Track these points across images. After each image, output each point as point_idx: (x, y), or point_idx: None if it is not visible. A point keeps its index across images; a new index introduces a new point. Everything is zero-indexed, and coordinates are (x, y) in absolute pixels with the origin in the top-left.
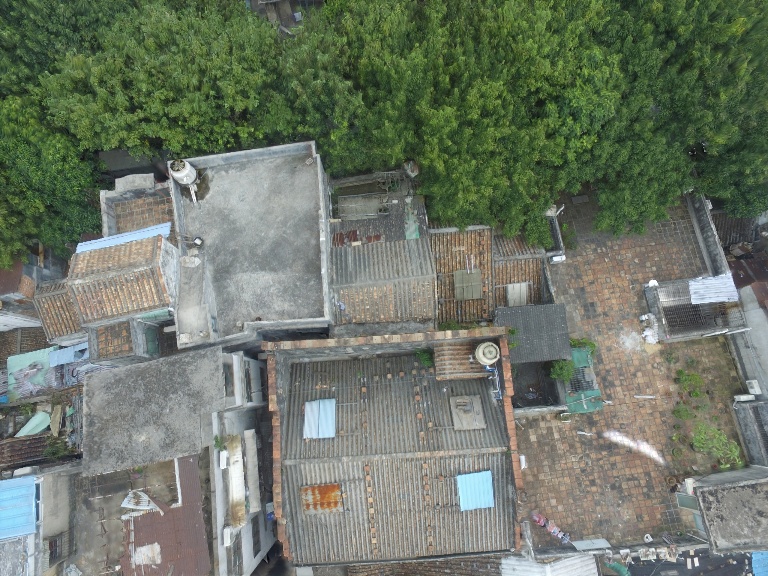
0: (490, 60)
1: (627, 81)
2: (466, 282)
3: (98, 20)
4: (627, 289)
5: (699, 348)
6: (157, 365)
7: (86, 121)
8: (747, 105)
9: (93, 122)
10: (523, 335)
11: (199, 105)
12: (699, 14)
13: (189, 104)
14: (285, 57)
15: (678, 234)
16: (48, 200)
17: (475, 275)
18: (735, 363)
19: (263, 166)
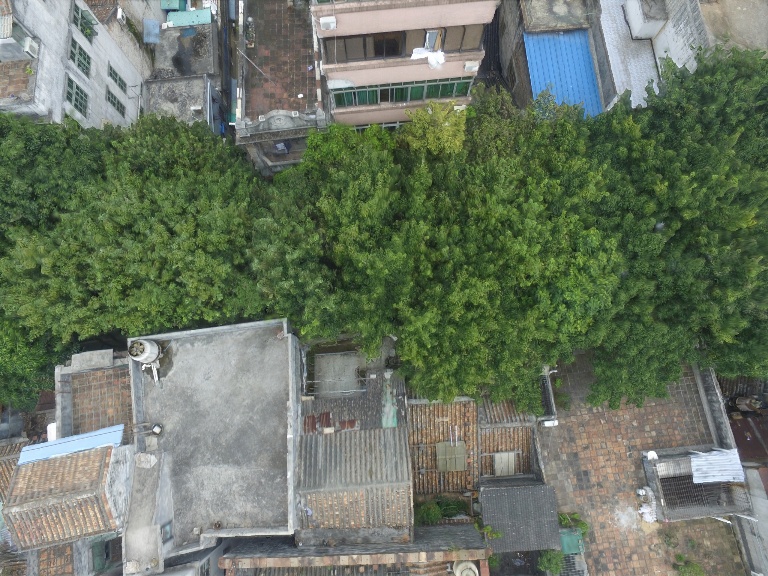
0: (477, 243)
1: (627, 258)
2: (449, 454)
3: (58, 185)
4: (624, 456)
5: (700, 528)
6: None
7: (34, 318)
8: (757, 297)
9: (43, 313)
10: (509, 521)
11: (158, 299)
12: (706, 197)
13: (147, 295)
14: (255, 236)
15: (680, 394)
16: (1, 371)
17: (459, 447)
18: (739, 546)
19: (231, 339)
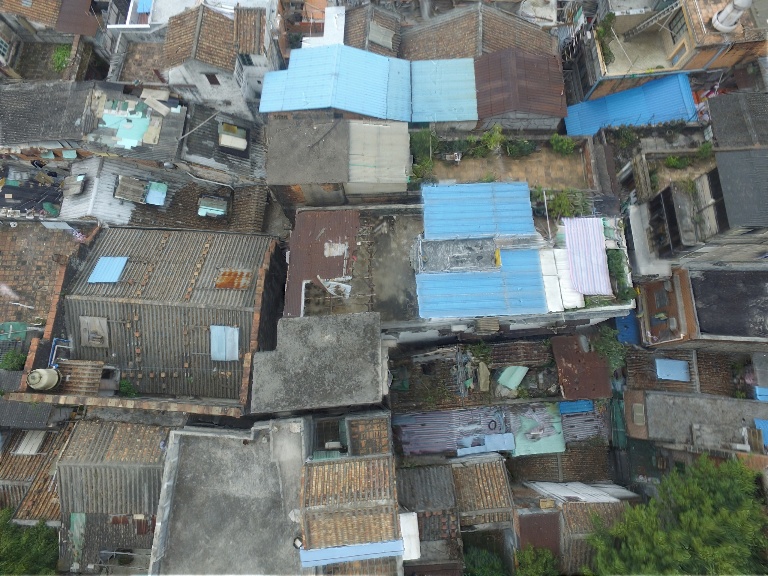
0: None
1: None
2: None
3: None
4: None
5: None
6: (312, 402)
7: None
8: None
9: None
10: None
11: None
12: None
13: None
14: None
15: None
16: None
17: None
18: None
19: None
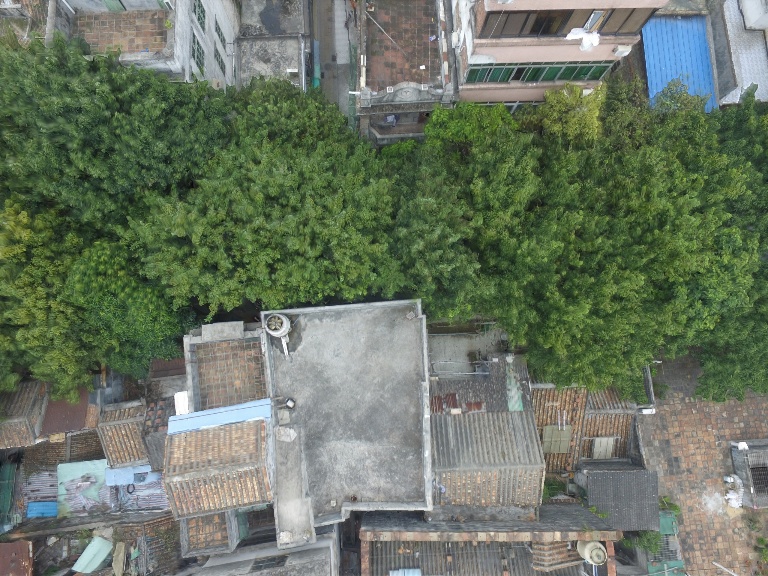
0: (623, 235)
1: None
2: (555, 437)
3: (192, 149)
4: (713, 445)
5: None
6: None
7: (186, 288)
8: None
9: None
10: (612, 502)
11: (311, 275)
12: None
13: (298, 271)
14: (402, 215)
15: None
16: (124, 337)
17: (565, 431)
18: None
19: (360, 316)
